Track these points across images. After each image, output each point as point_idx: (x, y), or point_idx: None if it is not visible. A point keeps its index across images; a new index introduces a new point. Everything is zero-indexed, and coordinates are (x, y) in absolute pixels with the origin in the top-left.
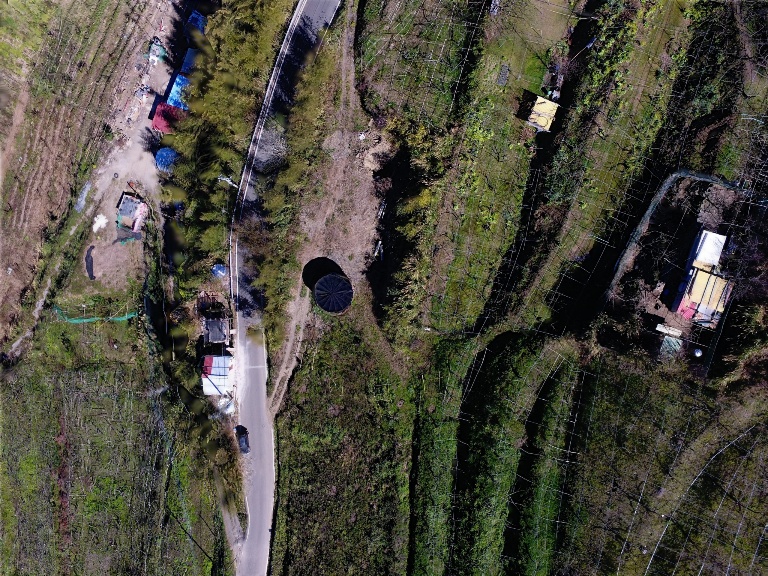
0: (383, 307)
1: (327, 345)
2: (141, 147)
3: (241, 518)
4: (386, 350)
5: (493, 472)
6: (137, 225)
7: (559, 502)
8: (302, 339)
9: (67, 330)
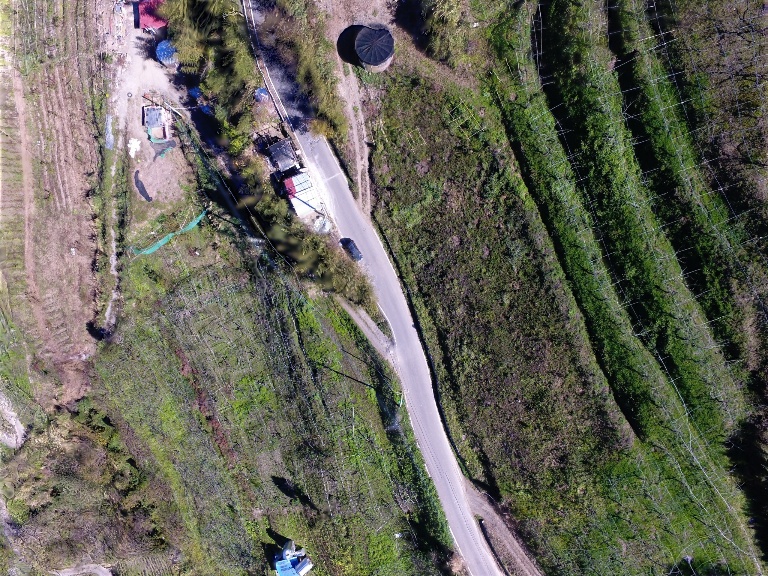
0: (425, 32)
1: (389, 110)
2: (140, 58)
3: (382, 327)
4: (446, 74)
5: (599, 105)
6: (167, 133)
7: (675, 84)
8: (364, 120)
9: (148, 262)
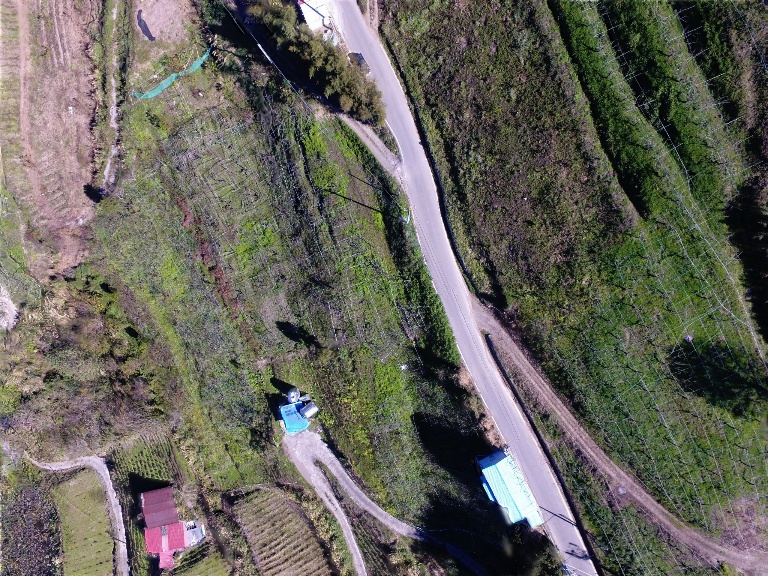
0: None
1: None
2: None
3: (389, 144)
4: None
5: None
6: None
7: None
8: None
9: (150, 107)
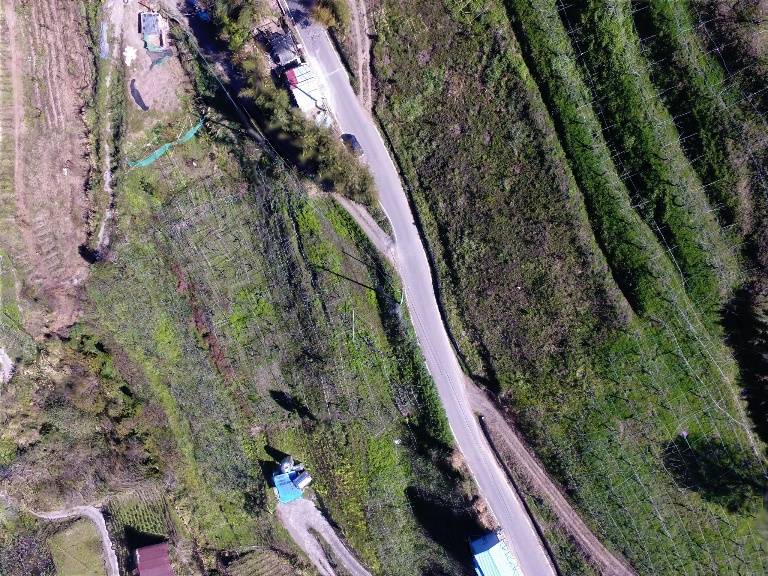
0: None
1: None
2: None
3: (383, 224)
4: None
5: None
6: (164, 41)
7: None
8: (366, 11)
9: (144, 175)
